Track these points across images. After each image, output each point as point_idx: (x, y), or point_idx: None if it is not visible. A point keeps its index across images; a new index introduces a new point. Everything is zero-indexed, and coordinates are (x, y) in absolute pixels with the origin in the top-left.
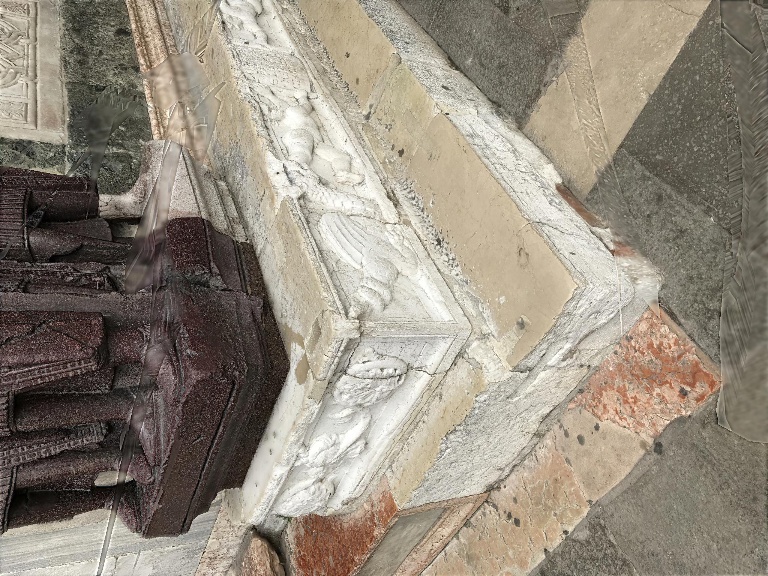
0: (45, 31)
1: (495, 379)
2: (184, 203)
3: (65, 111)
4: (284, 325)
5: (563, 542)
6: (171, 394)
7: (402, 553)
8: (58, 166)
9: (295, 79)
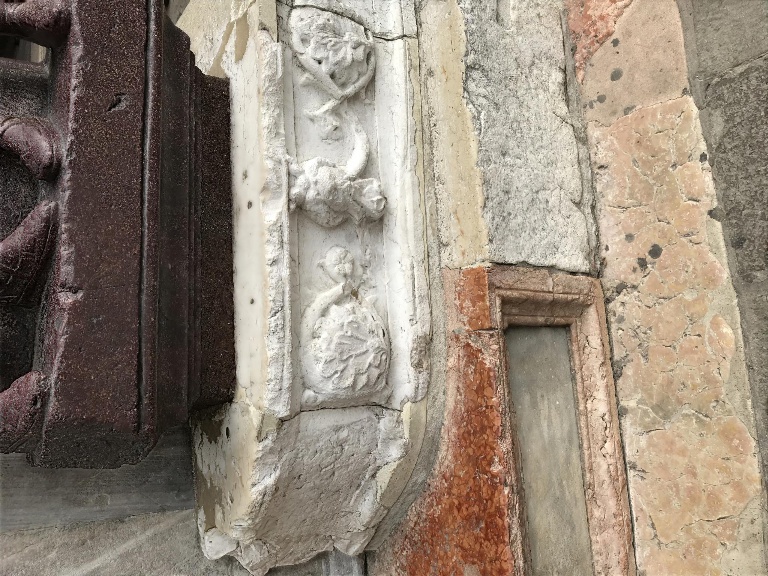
0: None
1: None
2: None
3: None
4: None
5: (713, 171)
6: None
7: (574, 510)
8: None
9: None
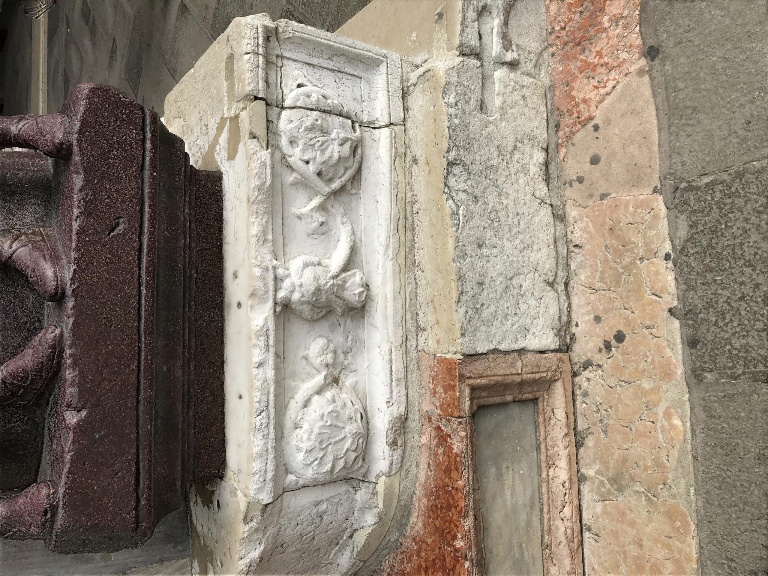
0: None
1: (449, 66)
2: None
3: None
4: (202, 162)
5: (676, 271)
6: (58, 125)
7: (532, 569)
8: None
9: None
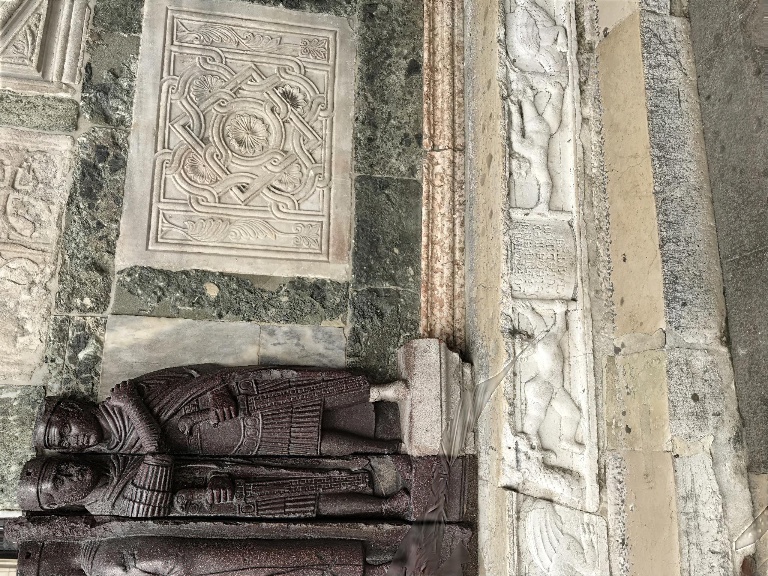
0: (342, 89)
1: None
2: (432, 437)
3: (352, 228)
4: (482, 558)
5: None
6: None
7: None
8: (342, 315)
9: (561, 283)
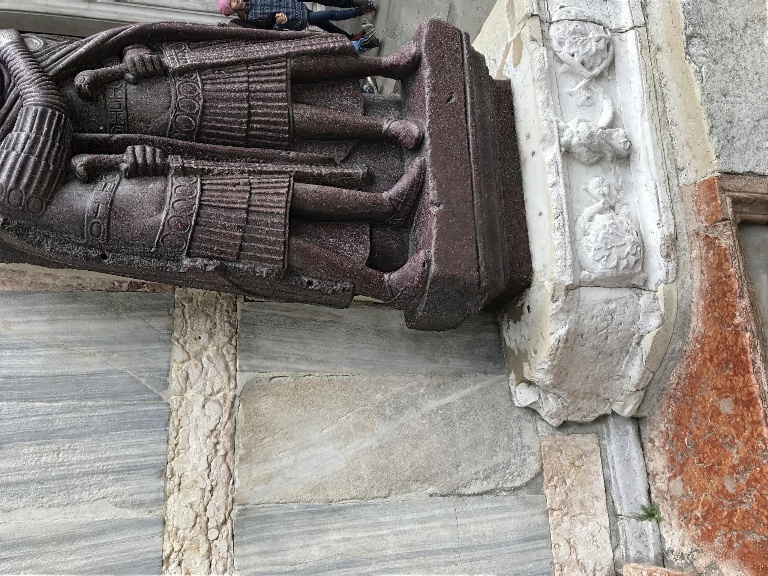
0: None
1: None
2: None
3: None
4: None
5: None
6: (412, 44)
7: None
8: None
9: None
